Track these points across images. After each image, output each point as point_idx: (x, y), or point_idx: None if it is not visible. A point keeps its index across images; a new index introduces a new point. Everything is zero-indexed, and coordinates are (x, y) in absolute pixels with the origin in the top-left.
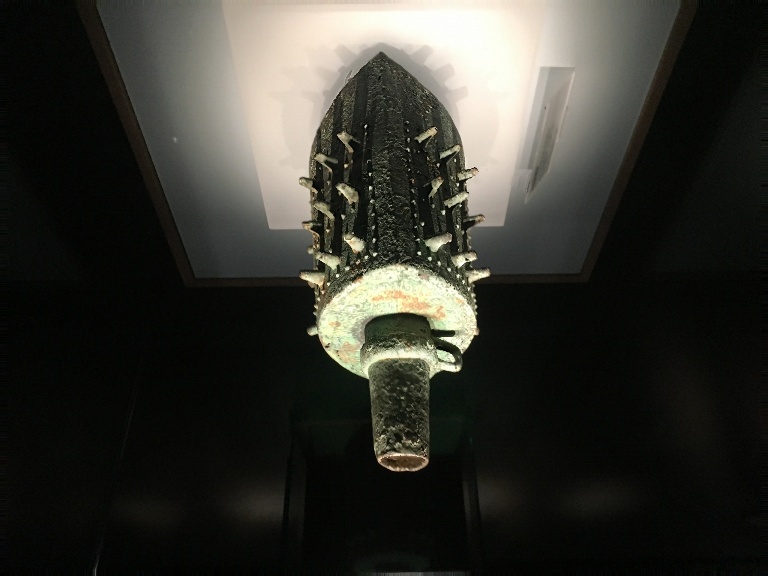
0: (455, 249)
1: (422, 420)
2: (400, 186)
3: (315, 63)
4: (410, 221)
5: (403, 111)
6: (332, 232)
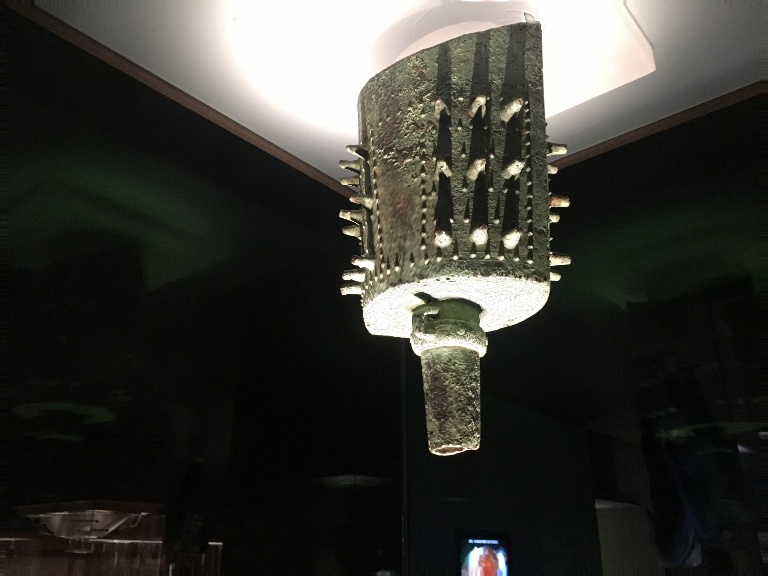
0: None
1: None
2: None
3: None
4: None
5: None
6: None
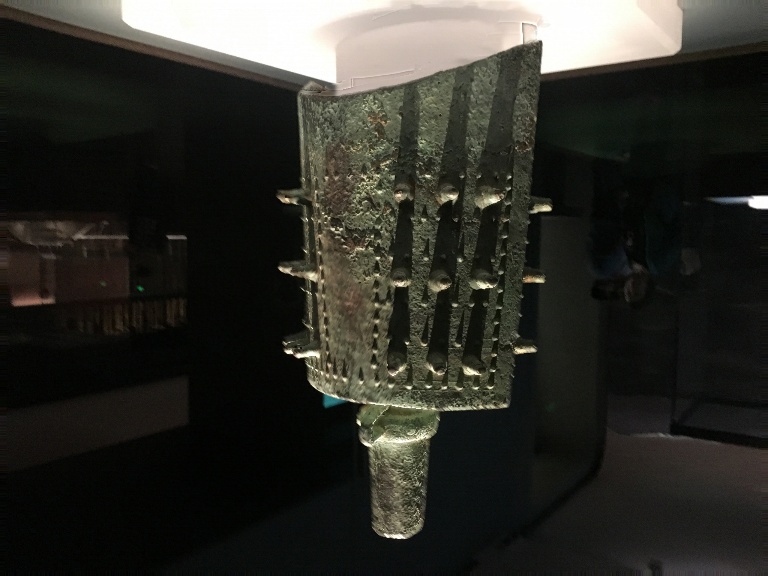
0: None
1: None
2: None
3: None
4: None
5: None
6: None
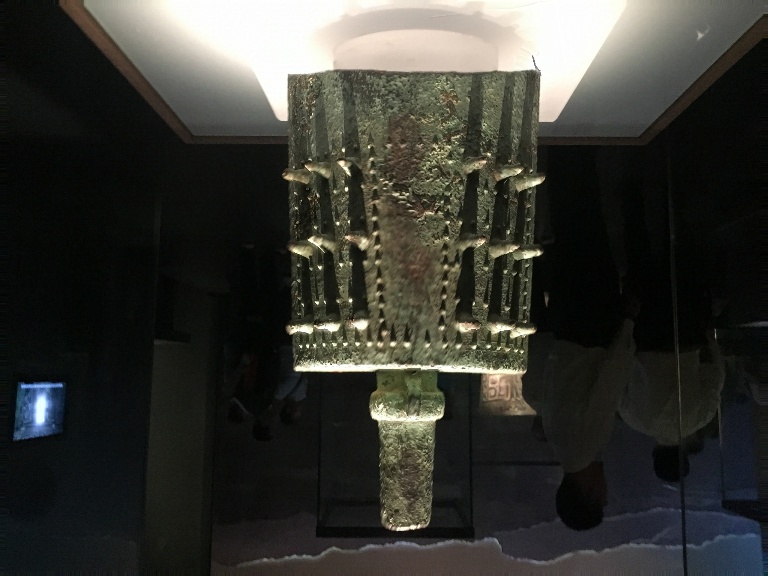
0: (334, 306)
1: (386, 489)
2: (293, 267)
3: None
4: (297, 309)
5: (295, 150)
6: None
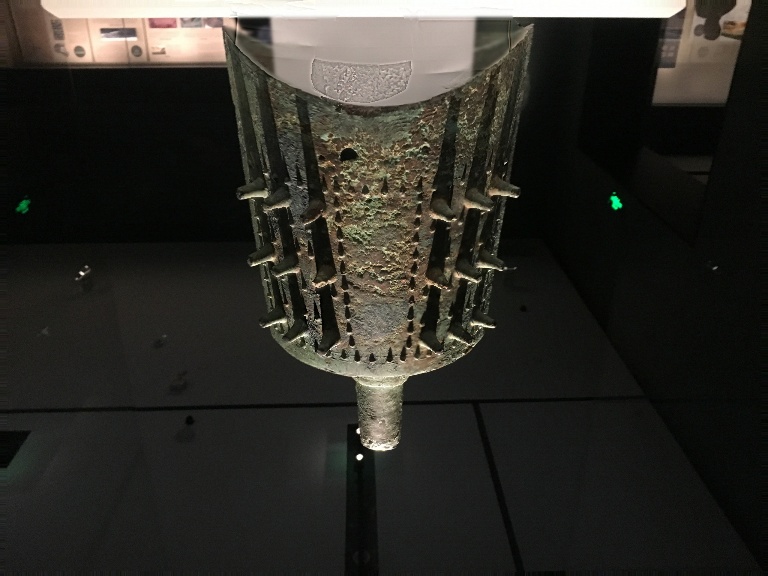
0: None
1: None
2: None
3: (525, 6)
4: None
5: None
6: (455, 294)
